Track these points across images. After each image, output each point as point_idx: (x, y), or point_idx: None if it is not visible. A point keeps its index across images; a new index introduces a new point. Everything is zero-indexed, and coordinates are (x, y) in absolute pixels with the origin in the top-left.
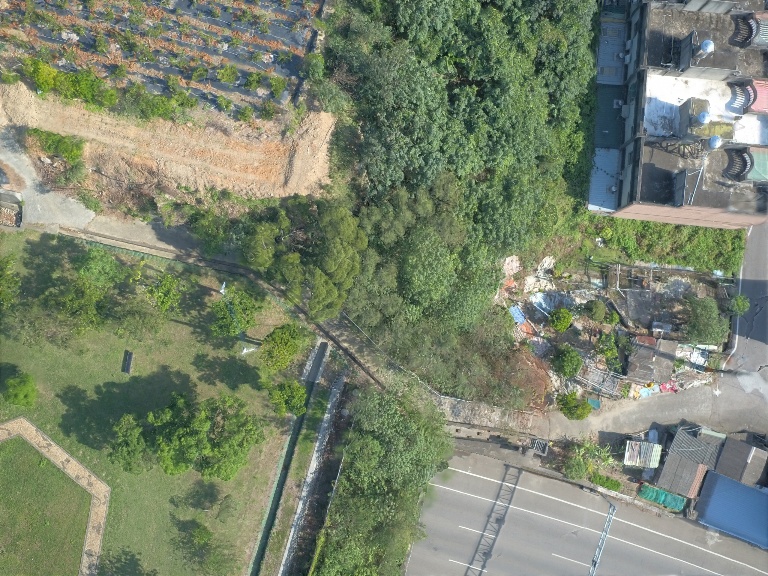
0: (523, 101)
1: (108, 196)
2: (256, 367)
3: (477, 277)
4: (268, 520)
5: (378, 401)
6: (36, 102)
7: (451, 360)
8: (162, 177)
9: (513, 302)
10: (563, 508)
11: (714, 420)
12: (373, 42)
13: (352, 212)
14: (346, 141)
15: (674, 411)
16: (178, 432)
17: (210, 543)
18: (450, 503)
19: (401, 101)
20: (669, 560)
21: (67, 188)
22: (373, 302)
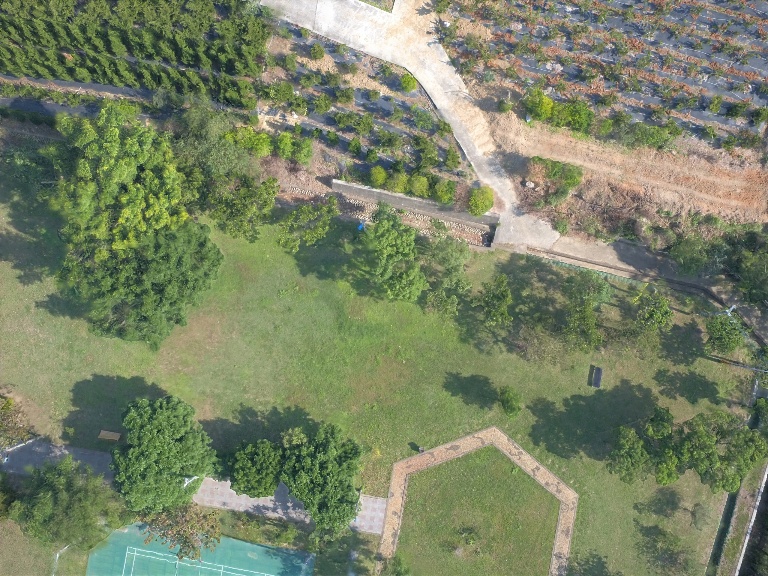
0: None
1: (577, 218)
2: (715, 383)
3: None
4: (719, 527)
5: None
6: (524, 129)
7: None
8: (646, 202)
9: None
10: None
11: None
12: None
13: None
14: None
15: None
16: (687, 446)
17: (672, 548)
18: None
19: None
20: None
21: (542, 211)
22: None
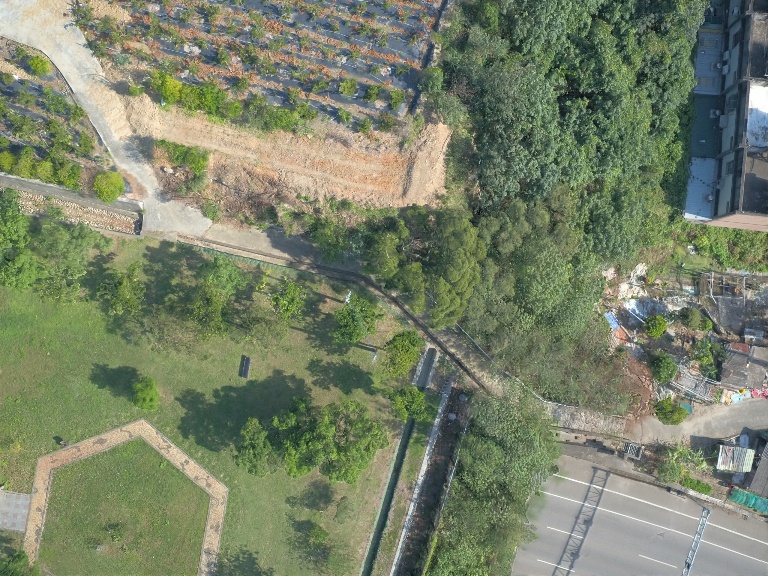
0: (632, 113)
1: (226, 205)
2: (369, 372)
3: (584, 285)
4: (379, 521)
5: (498, 407)
6: (160, 113)
7: (561, 367)
8: (283, 187)
9: (607, 308)
10: (650, 510)
11: None
12: (487, 55)
13: (472, 223)
14: (461, 152)
15: (765, 416)
16: (305, 436)
17: (325, 543)
18: (539, 504)
19: (520, 114)
20: (754, 562)
21: (187, 197)
22: (490, 310)
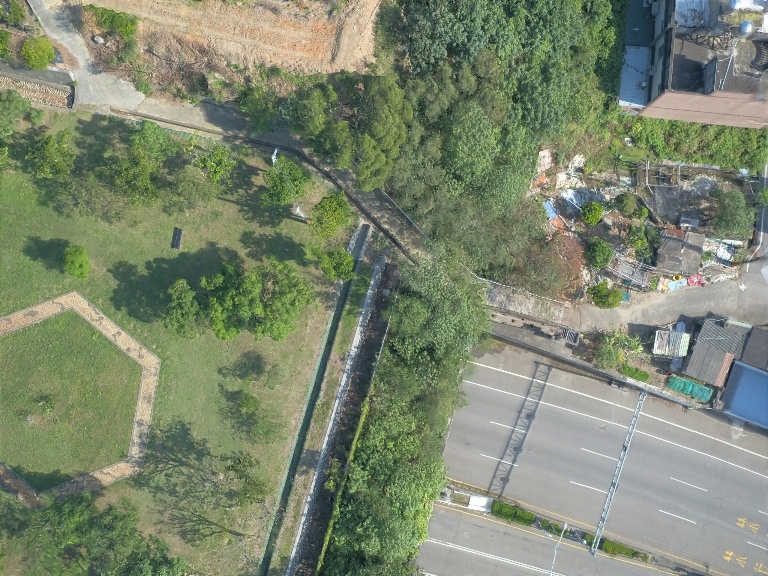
0: None
1: (158, 78)
2: (301, 244)
3: (515, 159)
4: (313, 394)
5: (424, 265)
6: None
7: (491, 236)
8: (212, 55)
9: (545, 198)
10: (592, 404)
11: (740, 314)
12: None
13: (398, 85)
14: (390, 22)
15: (701, 304)
16: (231, 293)
17: (257, 413)
18: (482, 399)
19: None
20: (695, 454)
21: (118, 69)
22: (418, 173)
